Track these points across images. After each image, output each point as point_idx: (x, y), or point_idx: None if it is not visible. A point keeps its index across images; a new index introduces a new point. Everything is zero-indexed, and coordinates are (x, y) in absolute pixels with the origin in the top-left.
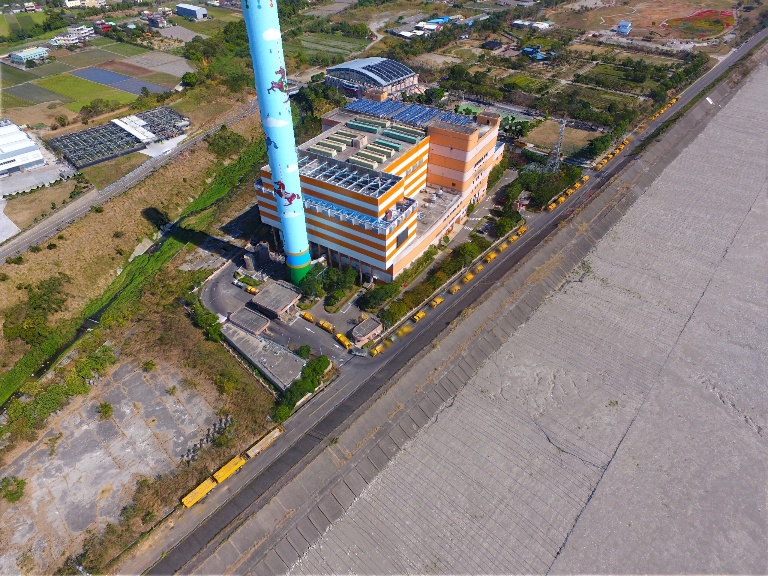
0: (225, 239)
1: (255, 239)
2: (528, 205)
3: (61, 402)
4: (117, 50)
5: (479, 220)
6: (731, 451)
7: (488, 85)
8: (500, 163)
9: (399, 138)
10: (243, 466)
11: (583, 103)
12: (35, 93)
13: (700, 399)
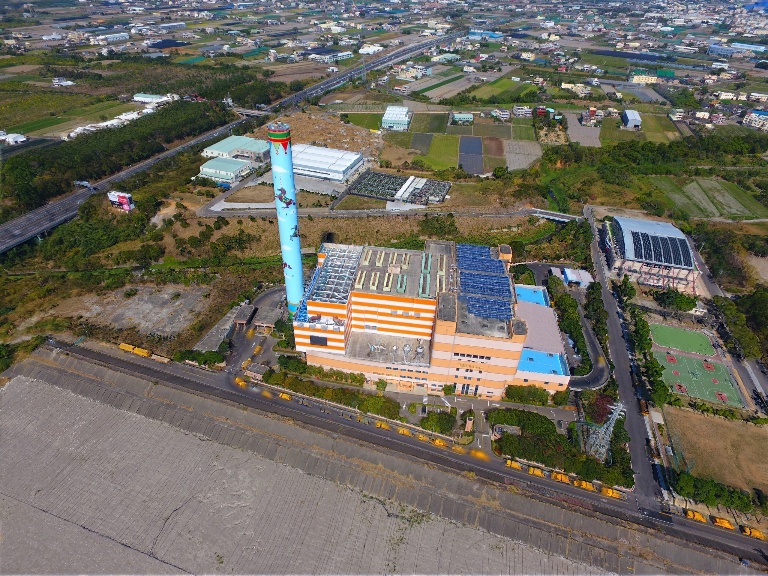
0: None
1: None
2: (498, 439)
3: (176, 281)
4: (518, 131)
5: (445, 405)
6: None
7: None
8: (557, 392)
9: None
10: (146, 357)
11: None
12: (422, 142)
13: None
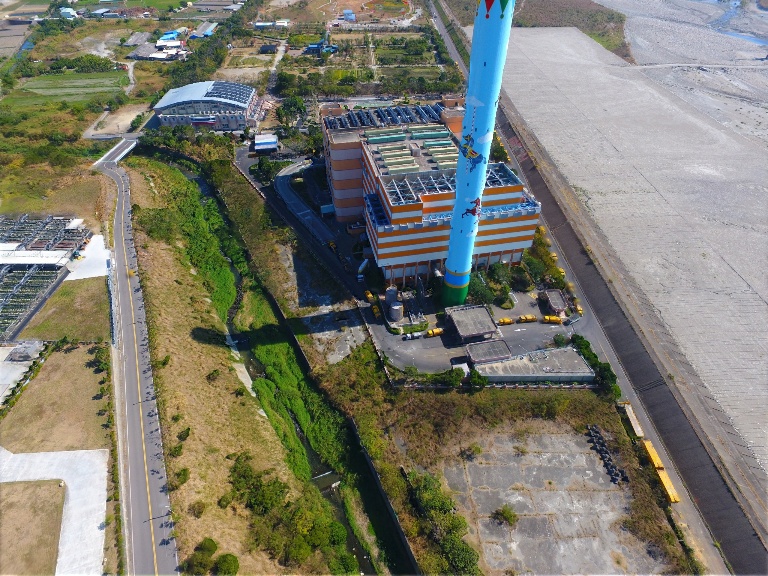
0: (323, 311)
1: (353, 294)
2: None
3: None
4: None
5: None
6: (763, 245)
7: (326, 84)
8: None
9: (431, 137)
10: None
11: (419, 79)
12: None
13: (721, 229)
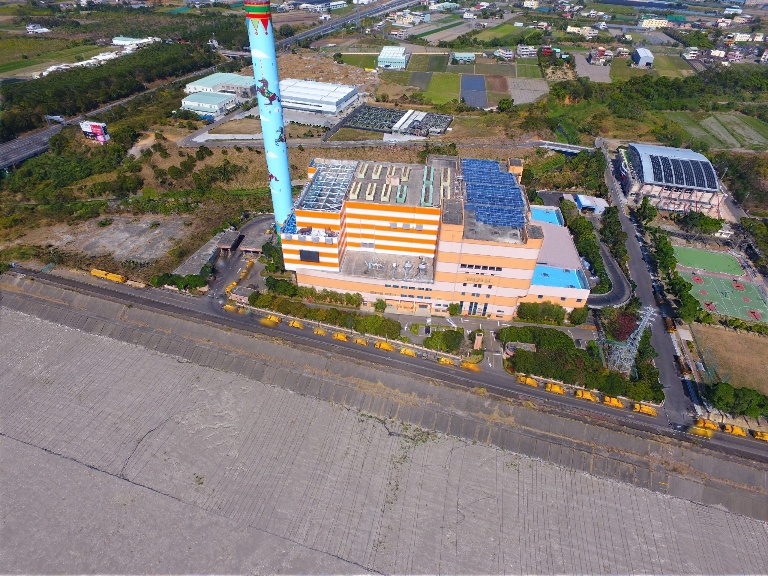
0: None
1: None
2: (511, 357)
3: (154, 210)
4: (522, 70)
5: (451, 325)
6: None
7: None
8: (574, 309)
9: None
10: (121, 283)
11: None
12: (421, 79)
13: (220, 574)
